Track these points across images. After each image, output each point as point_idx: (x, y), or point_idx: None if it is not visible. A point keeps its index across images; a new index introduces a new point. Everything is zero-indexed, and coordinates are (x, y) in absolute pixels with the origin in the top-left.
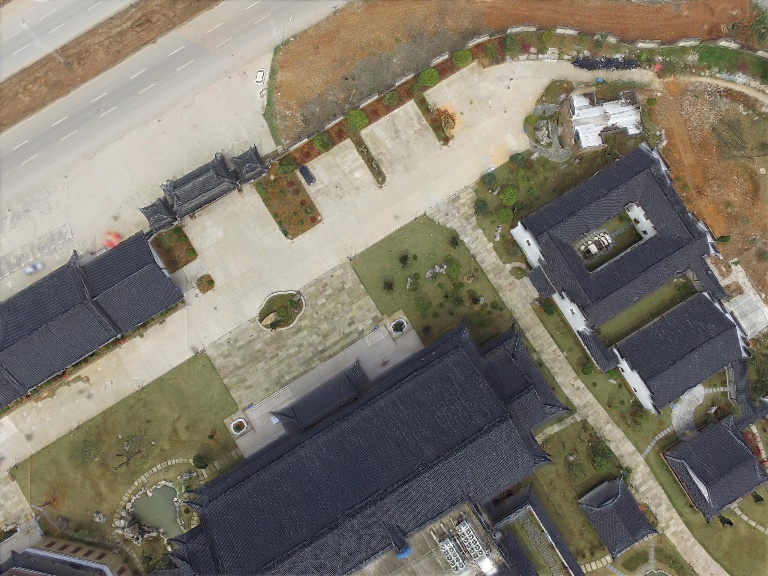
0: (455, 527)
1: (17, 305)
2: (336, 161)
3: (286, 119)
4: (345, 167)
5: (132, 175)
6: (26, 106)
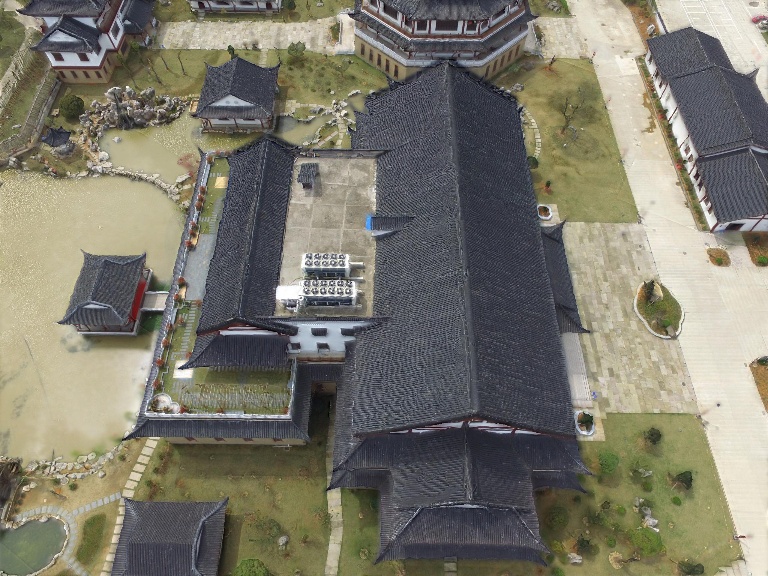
0: None
1: (760, 103)
2: None
3: None
4: None
5: None
6: None
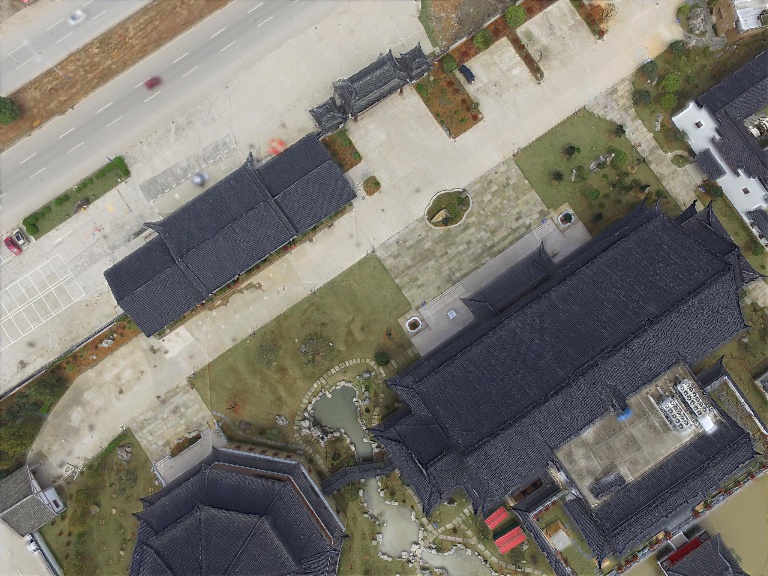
0: (677, 386)
1: (197, 208)
2: (493, 60)
3: (441, 21)
4: (503, 65)
5: (292, 83)
6: (184, 19)
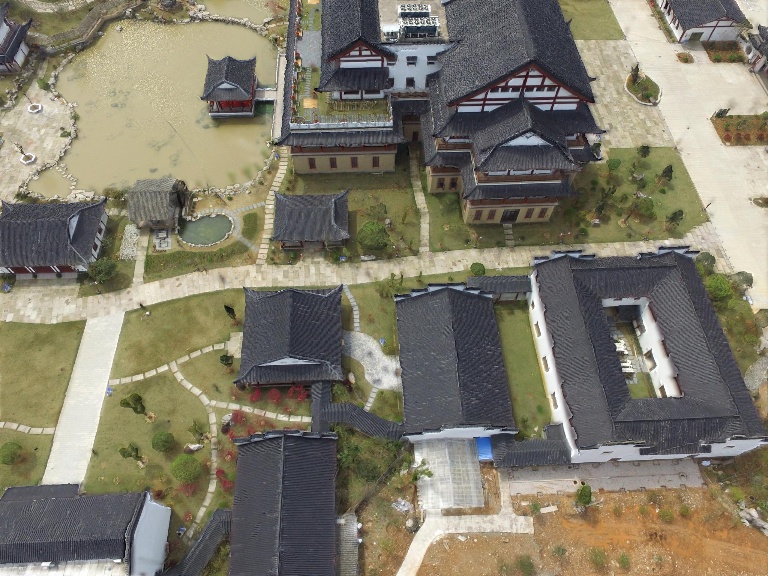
0: None
1: None
2: None
3: None
4: None
5: None
6: None
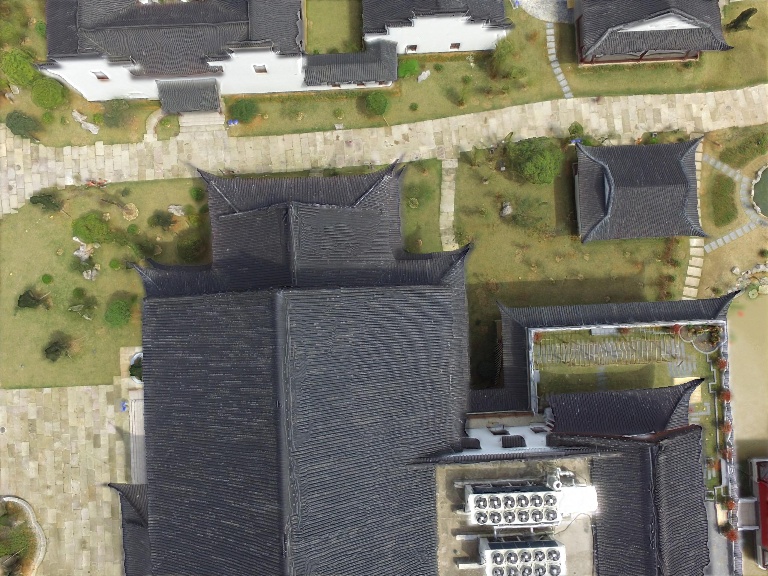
0: None
1: None
2: None
3: None
4: None
5: None
6: None
